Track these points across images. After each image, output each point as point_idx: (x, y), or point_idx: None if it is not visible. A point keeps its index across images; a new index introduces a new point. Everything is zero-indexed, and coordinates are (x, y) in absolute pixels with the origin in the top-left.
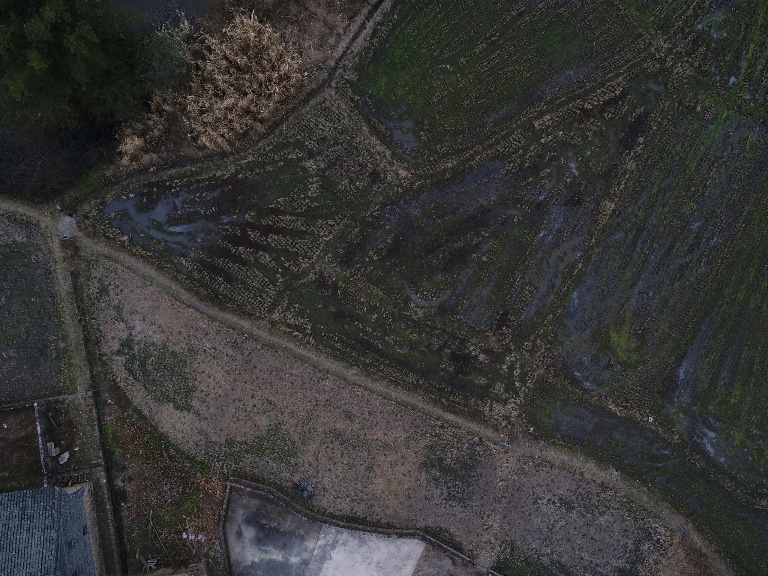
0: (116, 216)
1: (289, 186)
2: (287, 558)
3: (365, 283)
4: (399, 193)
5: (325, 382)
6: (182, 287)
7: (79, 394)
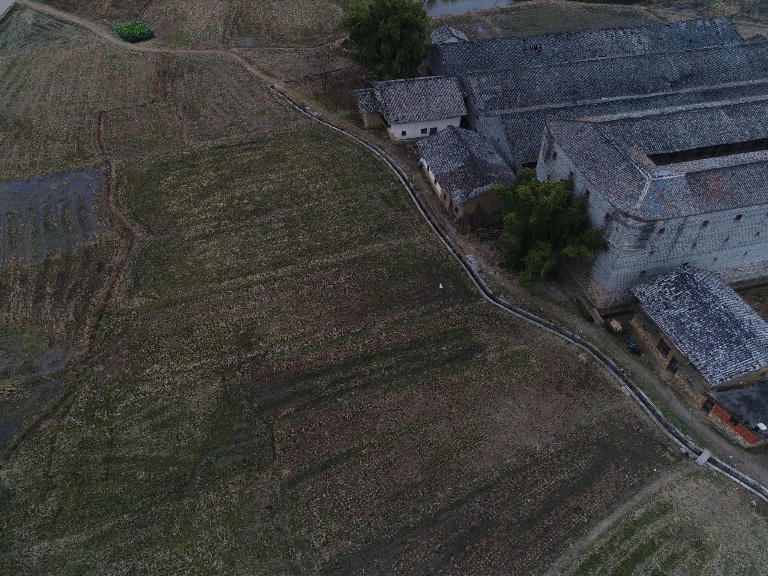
0: (658, 8)
1: (714, 3)
2: None
3: (759, 16)
4: (752, 4)
5: (766, 29)
6: (696, 15)
7: None
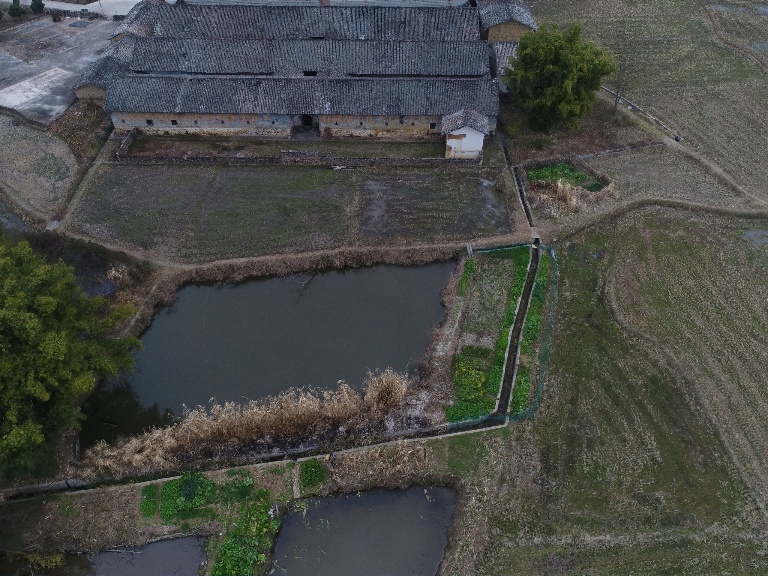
0: None
1: None
2: (42, 105)
3: None
4: None
5: None
6: None
7: (100, 162)
